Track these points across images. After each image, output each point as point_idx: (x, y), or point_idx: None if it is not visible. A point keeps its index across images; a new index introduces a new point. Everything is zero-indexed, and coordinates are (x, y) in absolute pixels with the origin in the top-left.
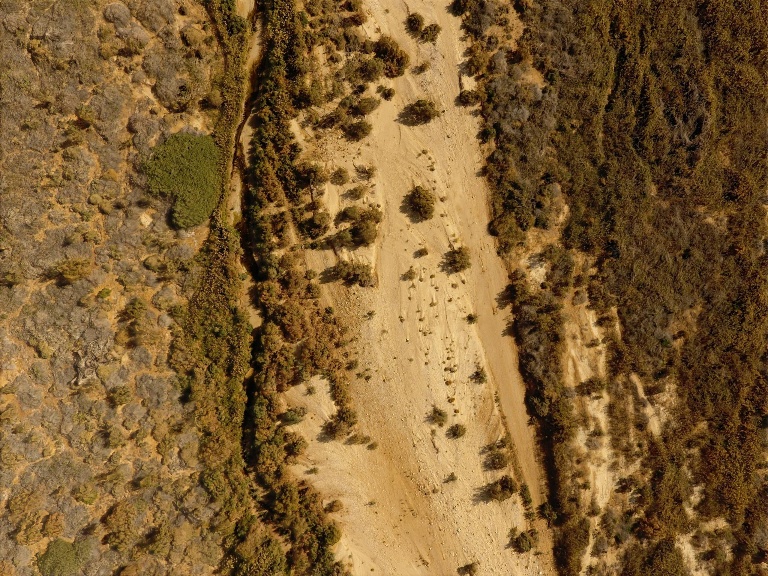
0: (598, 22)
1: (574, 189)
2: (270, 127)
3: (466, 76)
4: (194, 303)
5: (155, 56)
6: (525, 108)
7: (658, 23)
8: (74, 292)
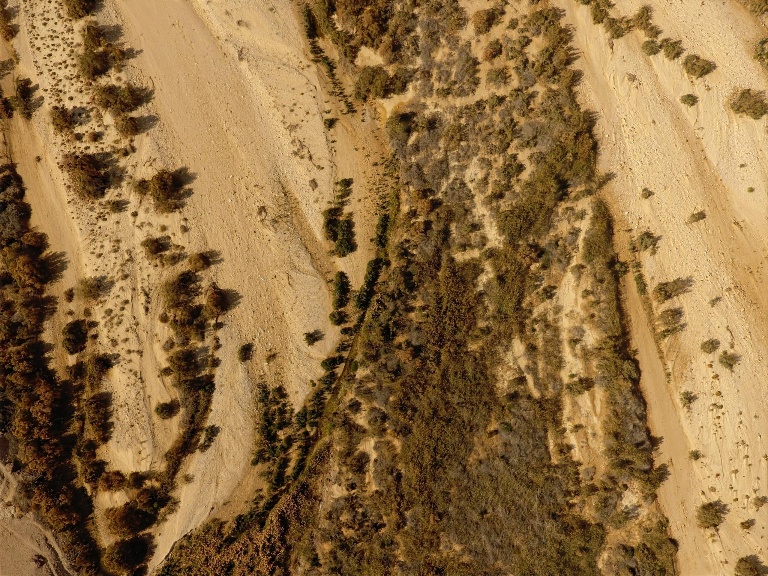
0: None
1: None
2: None
3: None
4: None
5: None
6: None
7: None
8: None
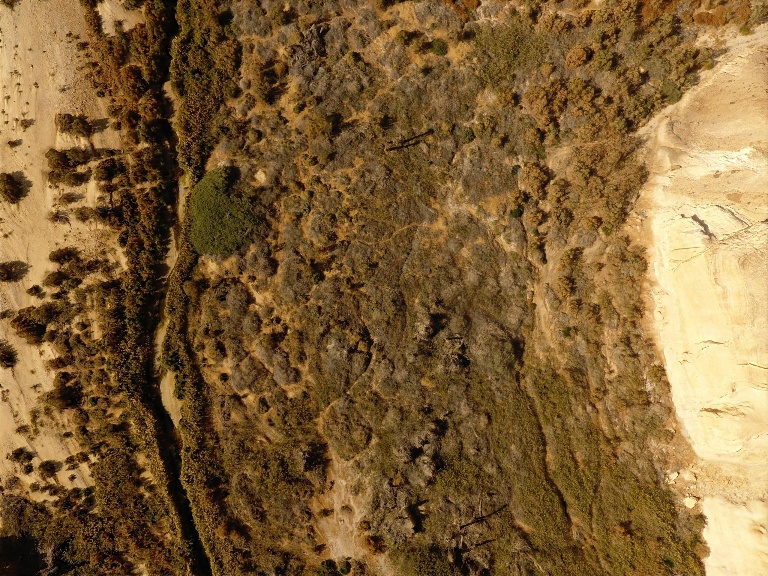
0: None
1: None
2: (144, 261)
3: None
4: (219, 100)
5: (250, 332)
6: None
7: None
8: (324, 110)
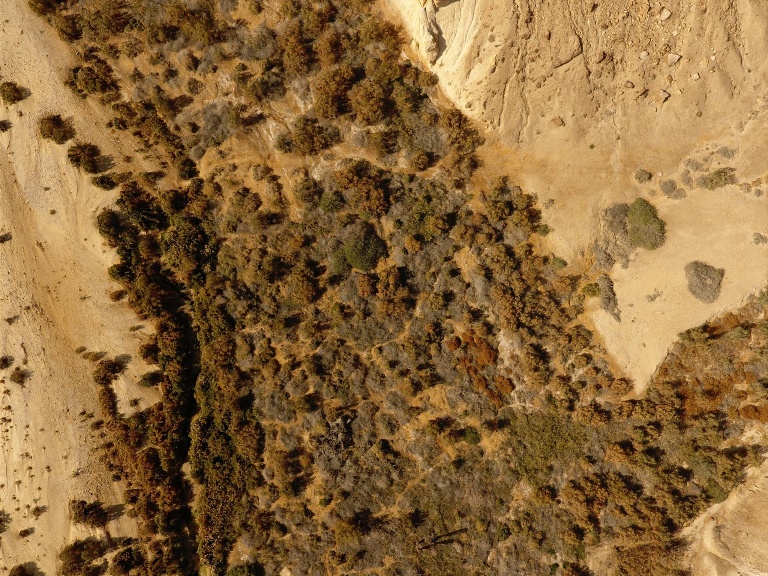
0: None
1: None
2: None
3: None
4: (241, 490)
5: None
6: None
7: None
8: (352, 505)
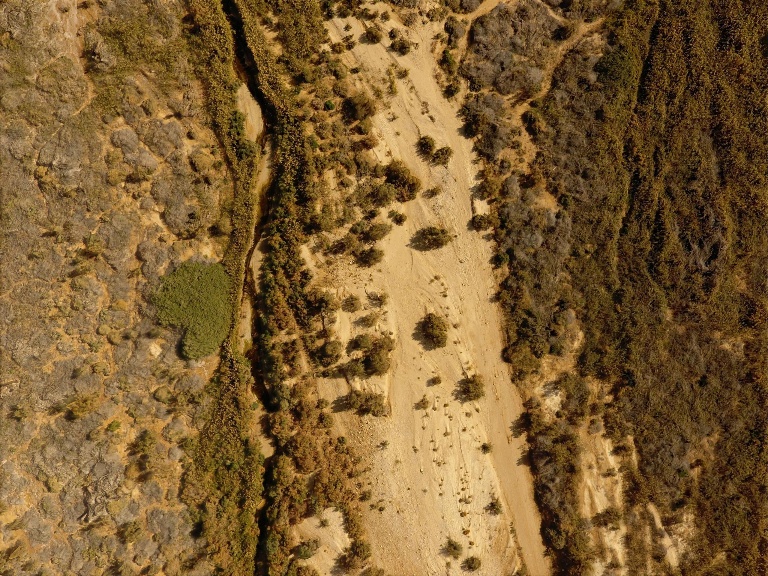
0: (612, 146)
1: (589, 316)
2: (280, 254)
3: (478, 200)
4: (205, 435)
5: (163, 182)
6: (539, 234)
7: (672, 146)
8: (83, 426)
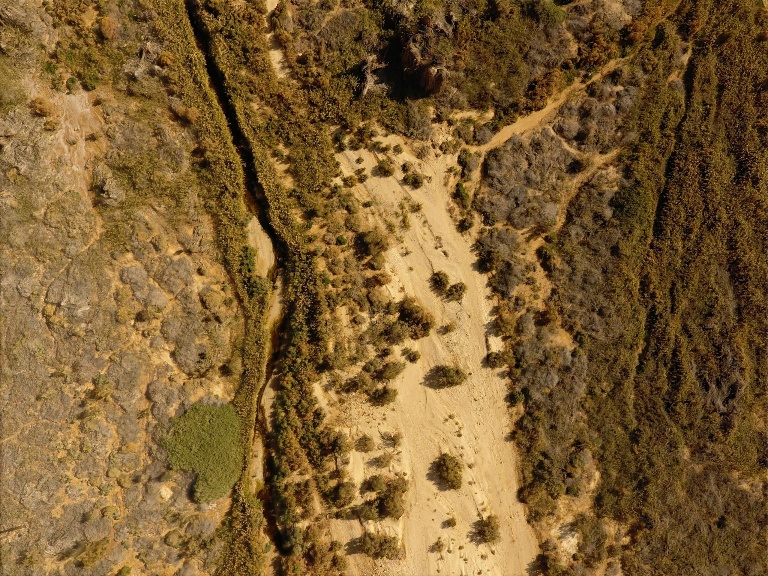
0: (628, 284)
1: (605, 457)
2: (293, 394)
3: (493, 336)
4: None
5: (173, 320)
6: (554, 373)
7: (689, 282)
8: (93, 572)
